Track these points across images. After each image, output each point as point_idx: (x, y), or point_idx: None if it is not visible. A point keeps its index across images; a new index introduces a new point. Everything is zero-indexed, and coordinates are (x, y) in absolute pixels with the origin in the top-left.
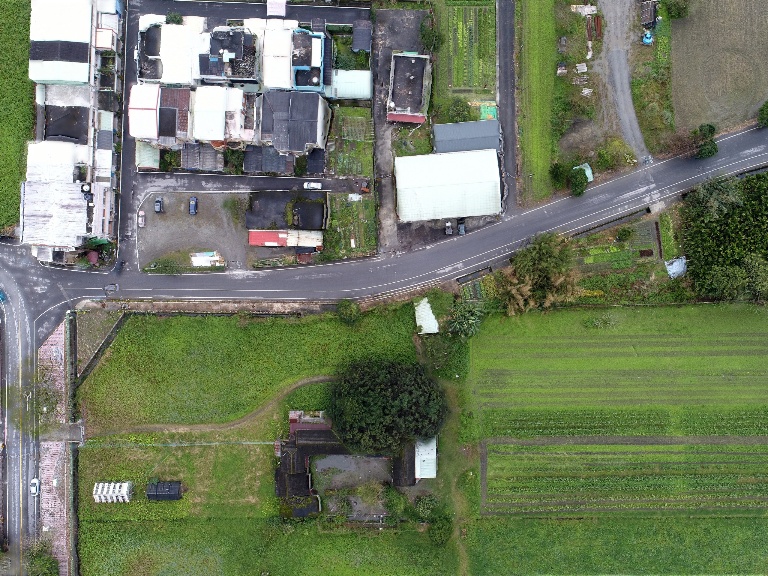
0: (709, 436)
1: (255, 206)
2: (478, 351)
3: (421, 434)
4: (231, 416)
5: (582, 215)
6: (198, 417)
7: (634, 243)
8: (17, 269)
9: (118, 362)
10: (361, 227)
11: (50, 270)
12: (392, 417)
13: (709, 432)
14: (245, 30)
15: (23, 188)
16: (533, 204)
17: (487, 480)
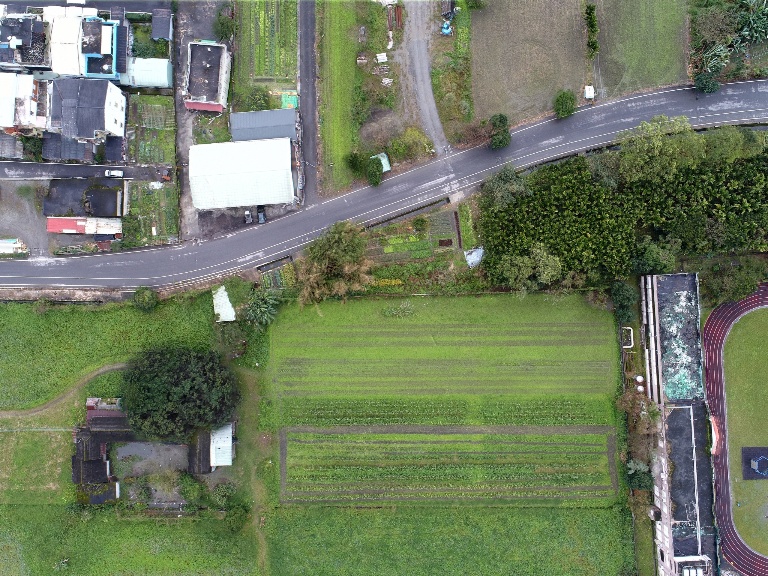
0: (507, 426)
1: (52, 193)
2: (278, 339)
3: (207, 421)
4: (32, 403)
5: (382, 204)
6: None
7: (433, 233)
8: None
9: None
10: (163, 215)
11: None
12: (175, 404)
13: (507, 422)
14: (37, 17)
15: None
16: (333, 193)
17: (286, 468)
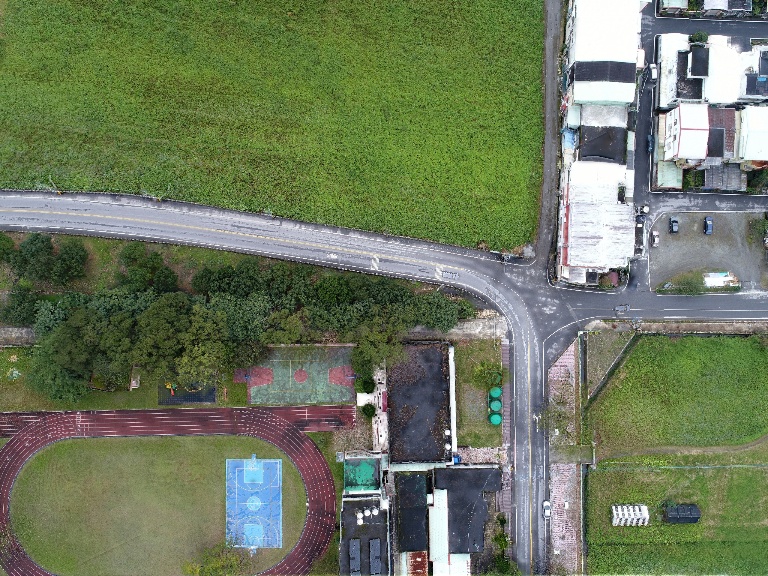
0: None
1: None
2: None
3: None
4: (747, 438)
5: None
6: (713, 439)
7: None
8: (526, 290)
9: (631, 383)
10: None
11: (559, 290)
12: None
13: None
14: None
15: (571, 209)
16: None
17: None
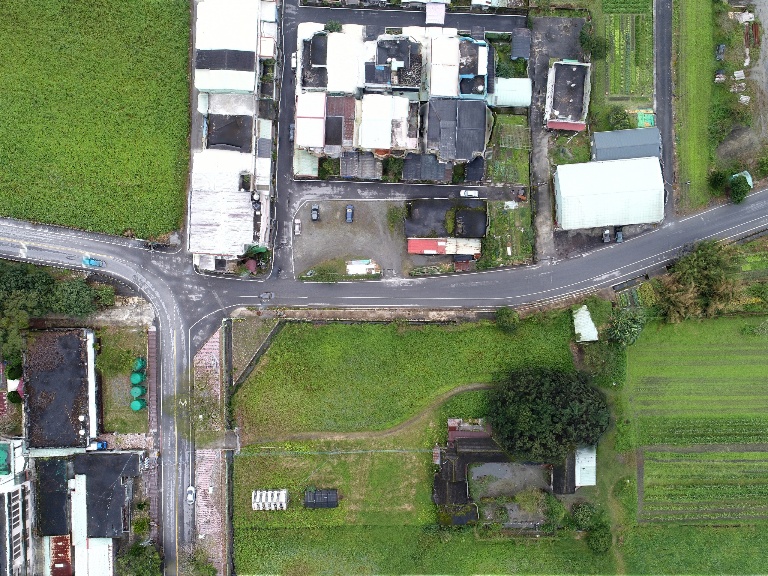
0: None
1: (415, 214)
2: (635, 359)
3: (588, 442)
4: (387, 424)
5: (739, 222)
6: (354, 425)
7: None
8: (172, 277)
9: (274, 370)
10: (517, 235)
11: (205, 278)
12: (562, 425)
13: None
14: (410, 38)
15: (190, 197)
16: (690, 211)
17: (644, 488)
